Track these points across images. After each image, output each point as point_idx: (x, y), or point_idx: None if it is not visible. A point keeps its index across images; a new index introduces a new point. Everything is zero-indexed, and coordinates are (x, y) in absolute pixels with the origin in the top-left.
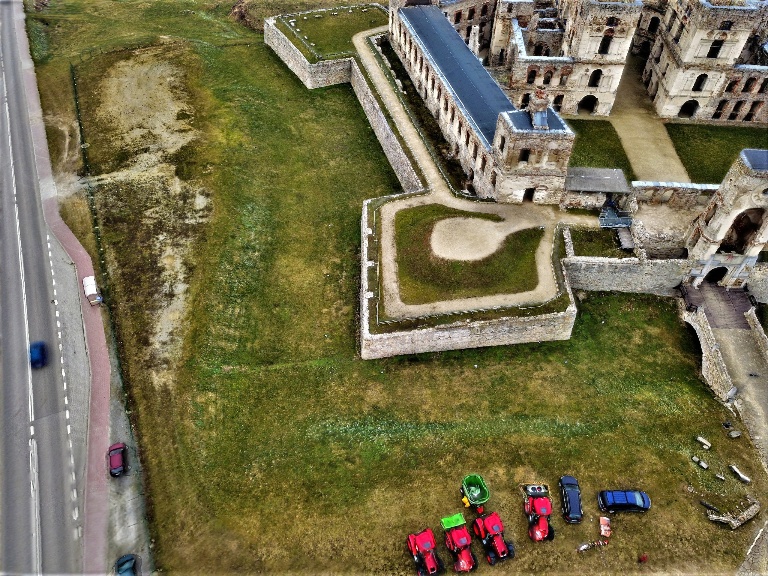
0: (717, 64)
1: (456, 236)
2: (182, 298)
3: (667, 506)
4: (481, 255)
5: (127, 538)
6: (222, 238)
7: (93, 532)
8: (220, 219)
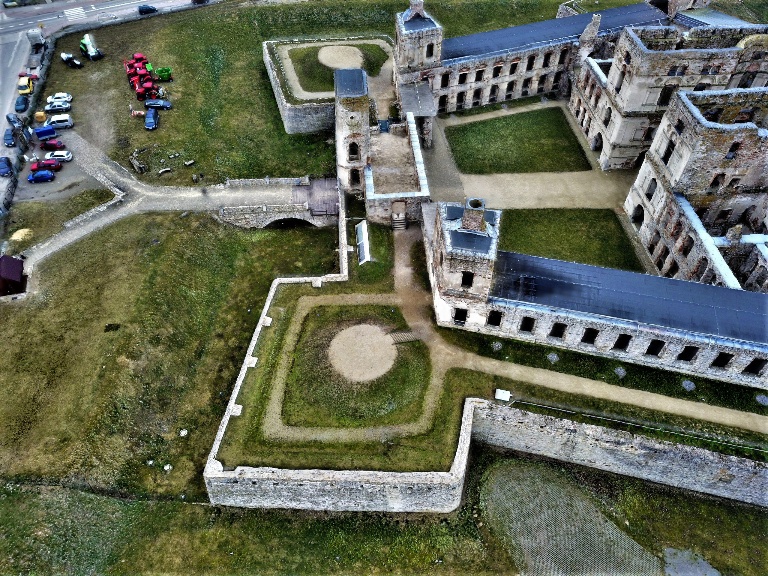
0: (665, 175)
1: (341, 53)
2: (297, 1)
3: (148, 137)
4: (324, 61)
5: (165, 9)
6: (347, 5)
7: (169, 3)
8: (364, 2)
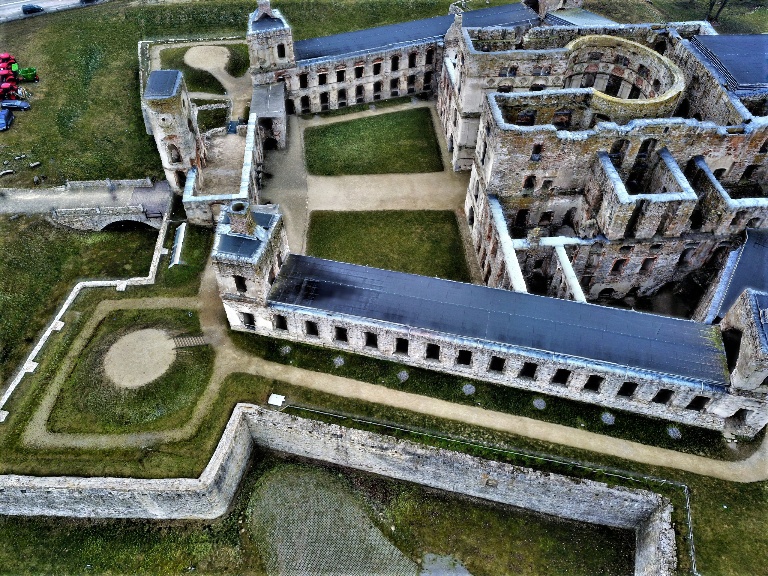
0: None
1: (209, 53)
2: (188, 0)
3: None
4: (188, 62)
5: (51, 8)
6: (238, 4)
7: (58, 2)
8: None
